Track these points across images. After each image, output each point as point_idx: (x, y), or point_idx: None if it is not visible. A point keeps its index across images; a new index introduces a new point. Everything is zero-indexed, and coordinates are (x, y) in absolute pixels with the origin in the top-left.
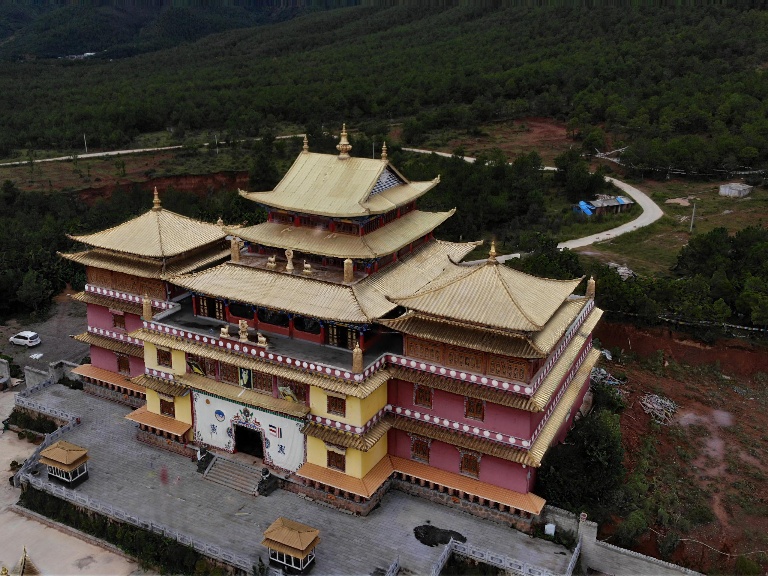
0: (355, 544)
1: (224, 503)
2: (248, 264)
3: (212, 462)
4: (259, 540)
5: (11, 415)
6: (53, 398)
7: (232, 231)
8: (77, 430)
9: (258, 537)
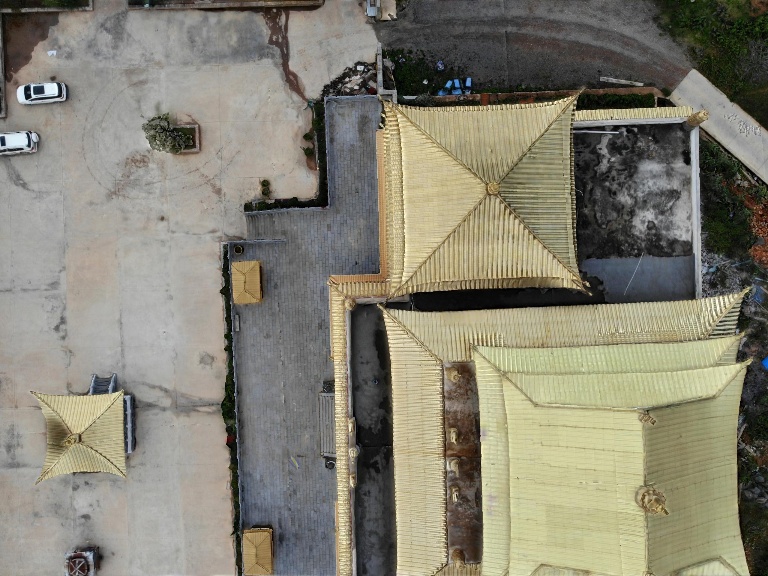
0: (310, 573)
1: (299, 438)
2: (448, 399)
3: (332, 395)
4: (274, 498)
5: (315, 107)
6: (353, 129)
7: (477, 356)
8: (318, 214)
9: (276, 495)
